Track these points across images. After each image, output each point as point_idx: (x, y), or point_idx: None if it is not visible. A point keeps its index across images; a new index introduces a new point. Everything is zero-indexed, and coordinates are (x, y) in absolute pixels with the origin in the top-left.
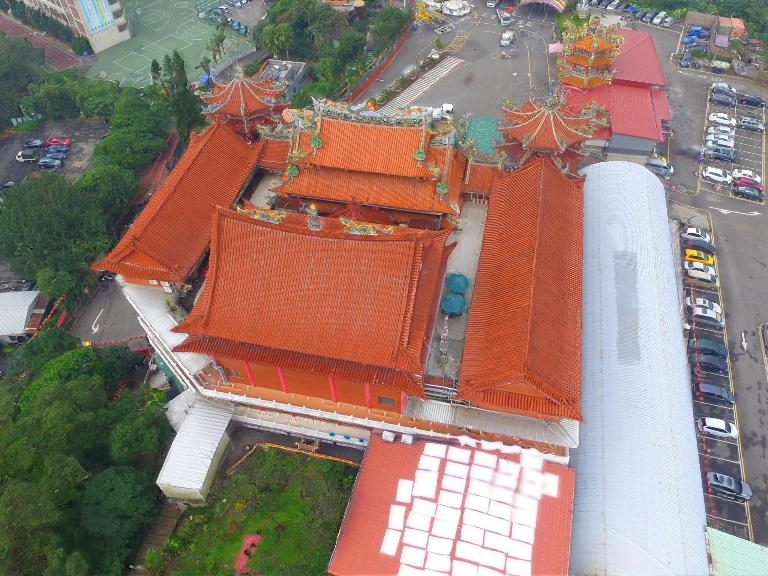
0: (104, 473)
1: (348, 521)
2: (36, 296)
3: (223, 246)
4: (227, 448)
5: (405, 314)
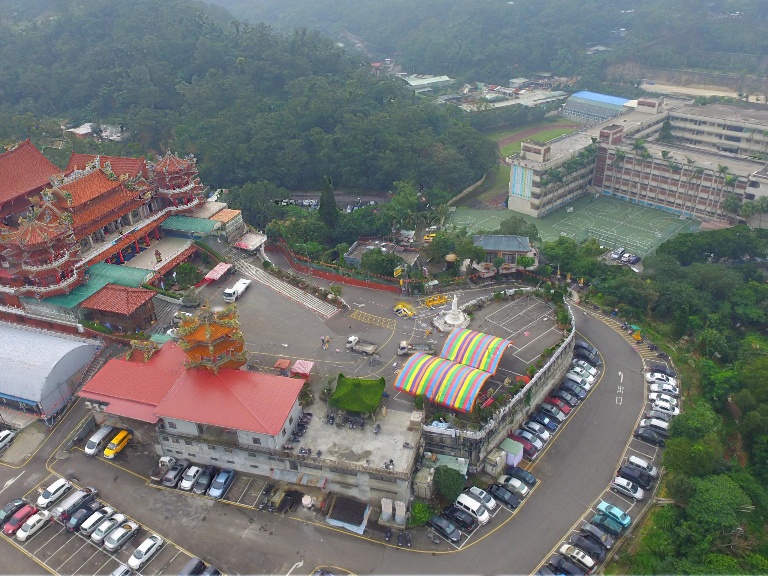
0: None
1: None
2: None
3: None
4: None
5: None
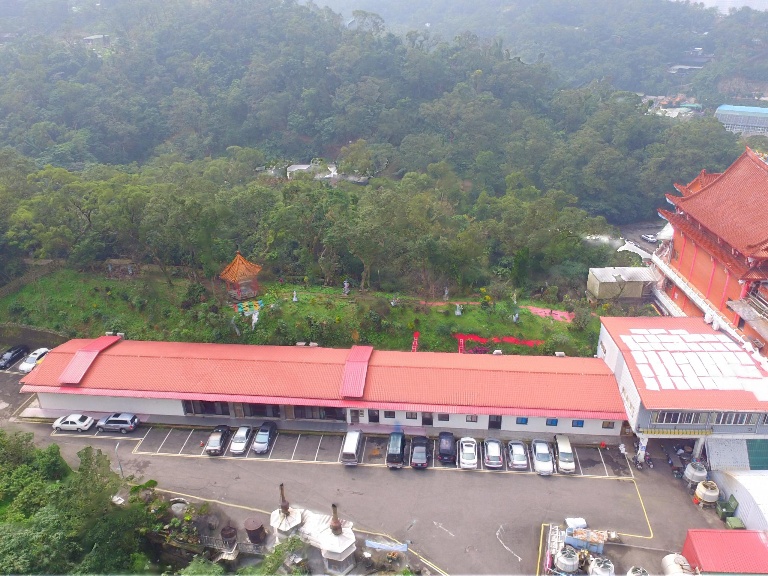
0: (579, 263)
1: (635, 318)
2: None
3: (732, 171)
4: (635, 300)
5: None
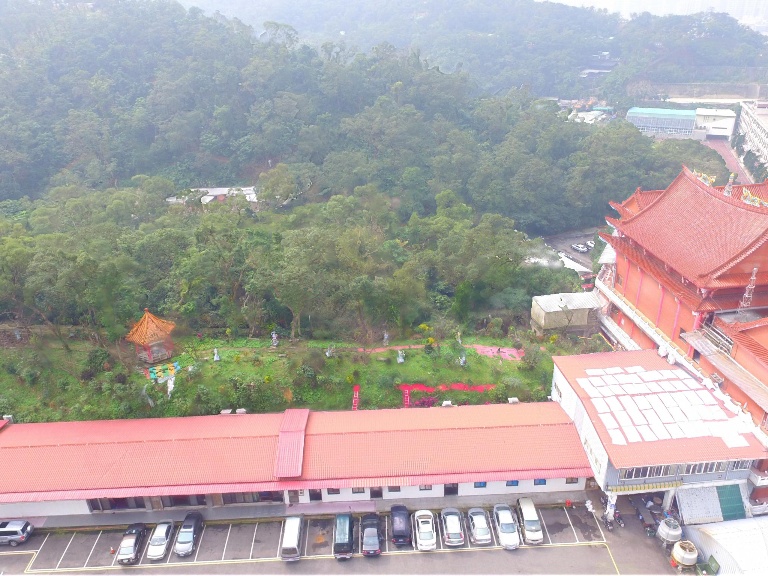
0: (520, 289)
1: (589, 355)
2: (588, 271)
3: (671, 191)
4: (581, 327)
5: (733, 260)
